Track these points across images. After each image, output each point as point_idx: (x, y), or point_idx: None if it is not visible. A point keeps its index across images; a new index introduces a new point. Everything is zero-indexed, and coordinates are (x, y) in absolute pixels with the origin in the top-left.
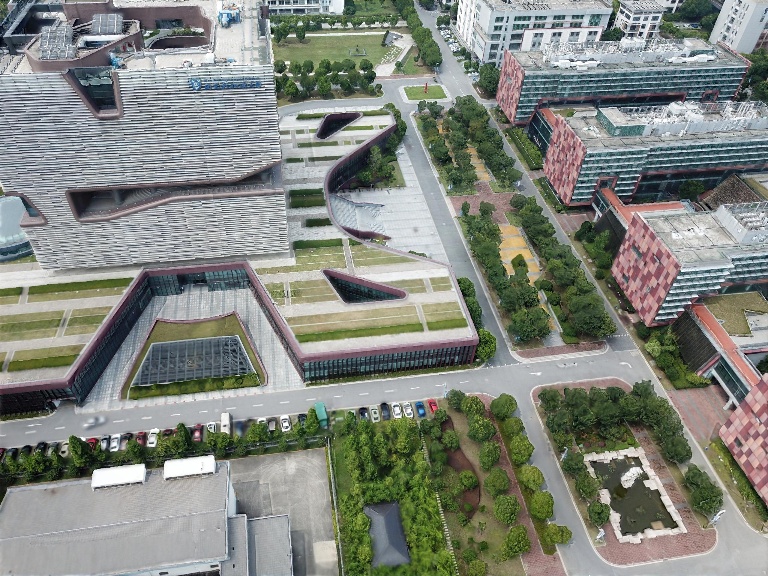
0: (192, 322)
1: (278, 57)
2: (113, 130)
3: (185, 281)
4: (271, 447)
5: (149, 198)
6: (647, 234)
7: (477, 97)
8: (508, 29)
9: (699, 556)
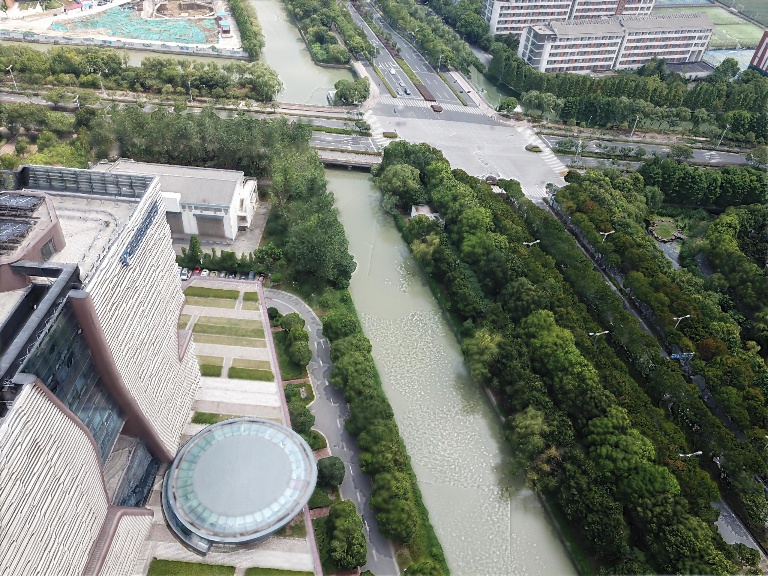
0: None
1: None
2: None
3: None
4: None
5: None
6: None
7: None
8: None
9: None
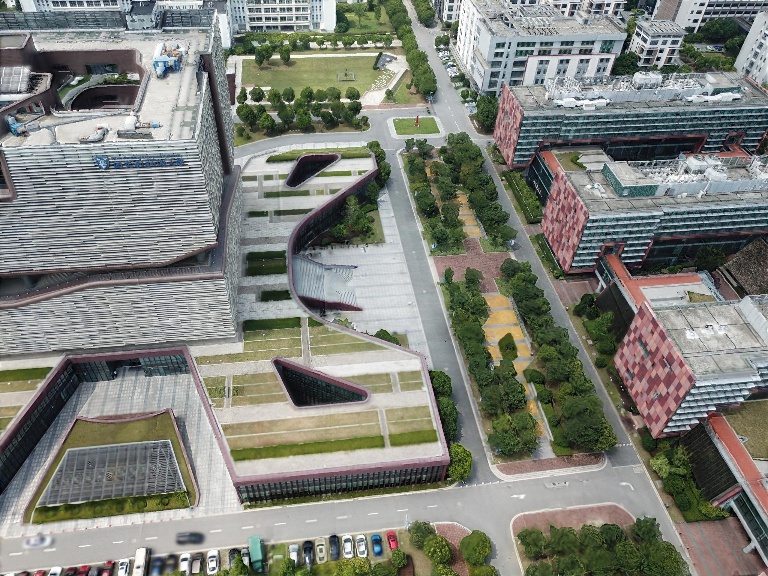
0: (118, 422)
1: (259, 82)
2: (7, 213)
3: (119, 363)
4: None
5: (64, 282)
6: (656, 331)
7: (473, 132)
8: (510, 56)
9: None
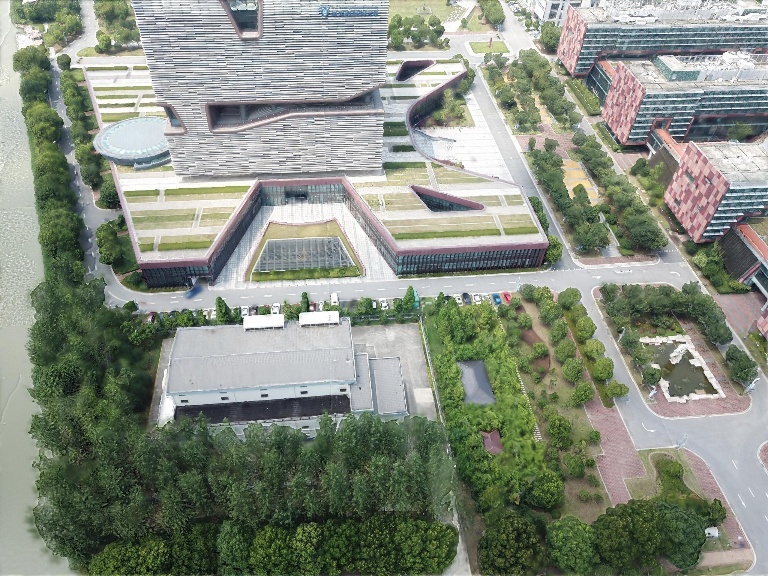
0: (299, 225)
1: None
2: (252, 50)
3: (288, 195)
4: (373, 321)
5: (270, 114)
6: (700, 159)
7: None
8: None
9: (735, 415)
